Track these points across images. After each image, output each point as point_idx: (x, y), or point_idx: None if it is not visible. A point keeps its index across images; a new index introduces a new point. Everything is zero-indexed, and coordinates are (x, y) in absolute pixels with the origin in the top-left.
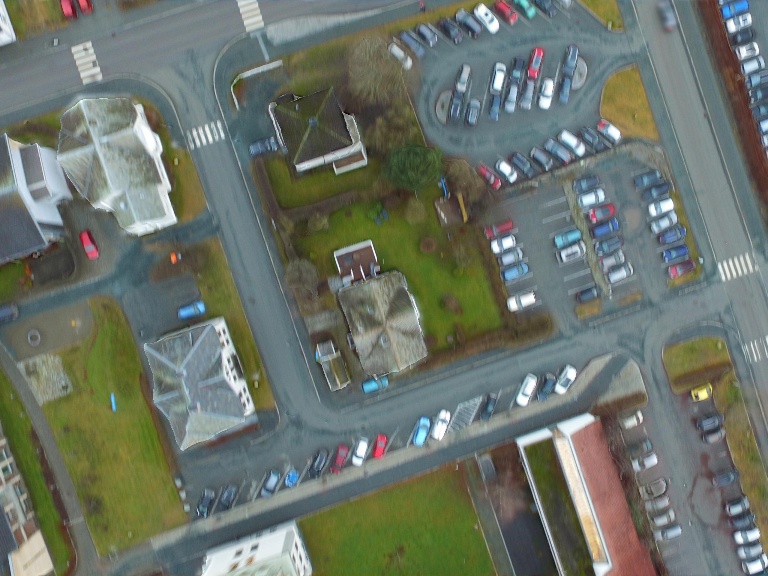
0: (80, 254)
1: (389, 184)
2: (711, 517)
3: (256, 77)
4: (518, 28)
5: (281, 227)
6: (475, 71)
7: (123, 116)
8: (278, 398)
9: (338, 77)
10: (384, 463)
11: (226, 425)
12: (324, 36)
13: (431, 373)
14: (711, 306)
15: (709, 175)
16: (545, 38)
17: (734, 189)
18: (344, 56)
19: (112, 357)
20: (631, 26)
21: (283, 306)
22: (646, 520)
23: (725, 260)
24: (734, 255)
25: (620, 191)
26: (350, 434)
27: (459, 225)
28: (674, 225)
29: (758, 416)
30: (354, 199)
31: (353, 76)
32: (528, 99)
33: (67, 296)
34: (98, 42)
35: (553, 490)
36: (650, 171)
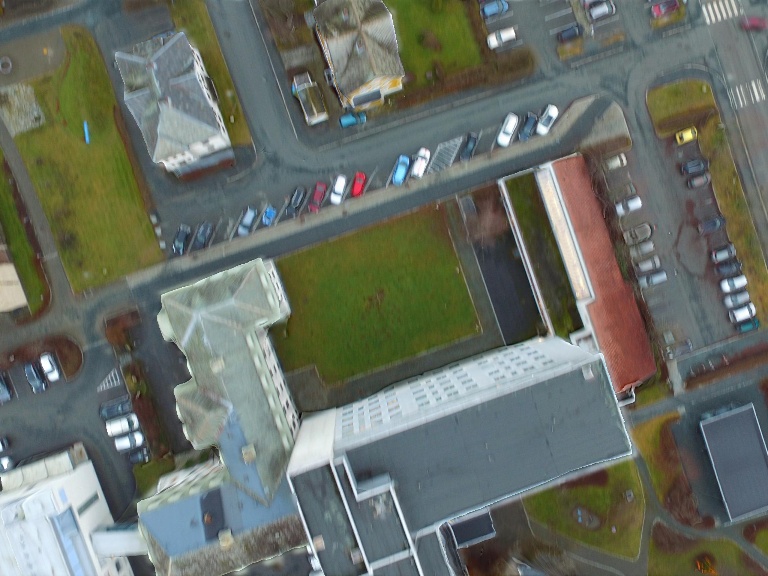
0: None
1: None
2: (697, 266)
3: None
4: None
5: None
6: None
7: None
8: (255, 135)
9: None
10: (363, 203)
11: (199, 134)
12: None
13: (410, 112)
14: (695, 49)
15: None
16: None
17: None
18: None
19: (85, 84)
20: None
21: (259, 40)
22: (631, 267)
23: (709, 3)
24: None
25: None
26: (328, 173)
27: None
28: None
29: (744, 163)
30: None
31: None
32: None
33: (39, 24)
34: None
35: (535, 226)
36: None
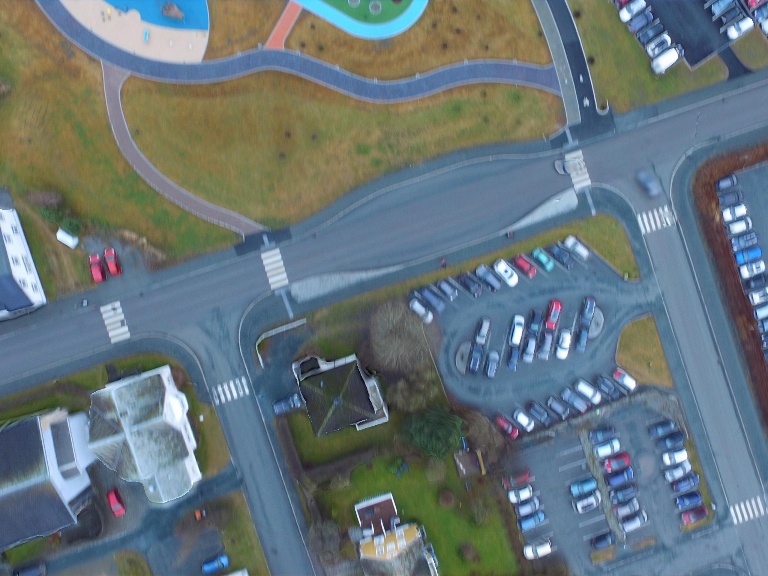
0: (107, 512)
1: (410, 446)
2: None
3: (280, 335)
4: (536, 280)
5: (304, 487)
6: (494, 322)
7: (152, 396)
8: None
9: (360, 330)
10: None
11: None
12: (347, 293)
13: None
14: (723, 549)
15: (722, 420)
16: (563, 289)
17: (746, 434)
18: (366, 311)
19: None
20: (647, 276)
21: (304, 556)
22: None
23: (737, 503)
24: (746, 498)
25: (635, 439)
26: None
27: (477, 476)
28: (687, 473)
29: None
30: (375, 454)
31: (376, 348)
32: (546, 351)
33: (94, 552)
34: (126, 302)
35: None
36: (664, 421)
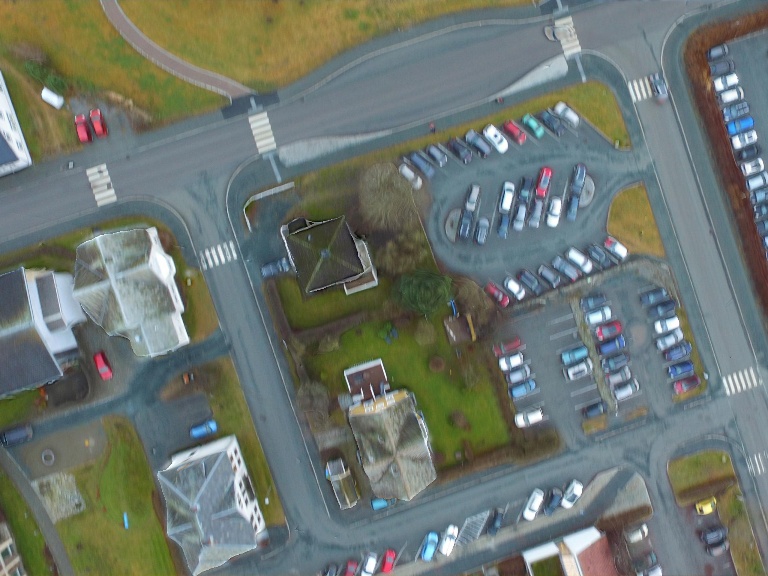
0: (94, 375)
1: (399, 307)
2: None
3: (268, 199)
4: (527, 147)
5: (292, 349)
6: (484, 189)
7: (138, 248)
8: (288, 514)
9: (349, 196)
10: None
11: (238, 552)
12: (335, 157)
13: (439, 488)
14: (716, 420)
15: (714, 291)
16: (553, 156)
17: (739, 304)
18: (355, 176)
19: (125, 477)
20: (638, 144)
21: (294, 423)
22: None
23: (730, 374)
24: (738, 369)
25: (626, 308)
26: (359, 549)
27: (468, 343)
28: (680, 342)
29: (761, 528)
30: (364, 319)
31: (364, 204)
32: (536, 218)
33: (81, 416)
34: (113, 164)
35: None
36: (656, 289)
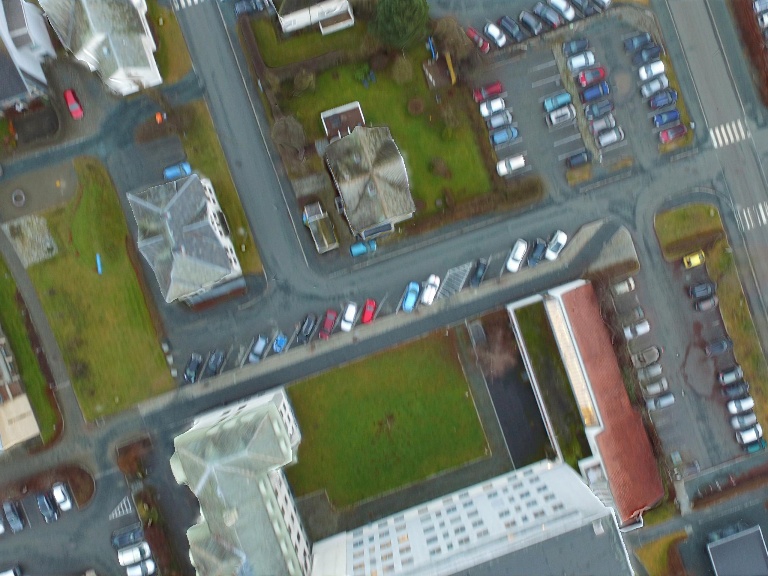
0: (64, 113)
1: (376, 40)
2: (704, 387)
3: None
4: None
5: (267, 85)
6: None
7: None
8: (266, 262)
9: None
10: (373, 329)
11: (212, 276)
12: None
13: (420, 238)
14: (703, 173)
15: (700, 40)
16: None
17: (726, 55)
18: None
19: (97, 217)
20: None
21: (270, 169)
22: (639, 389)
23: (717, 126)
24: (726, 121)
25: (610, 55)
26: (339, 299)
27: (447, 88)
28: (665, 89)
29: (751, 285)
30: (341, 59)
31: None
32: None
33: (52, 157)
34: None
35: (544, 354)
36: (640, 34)
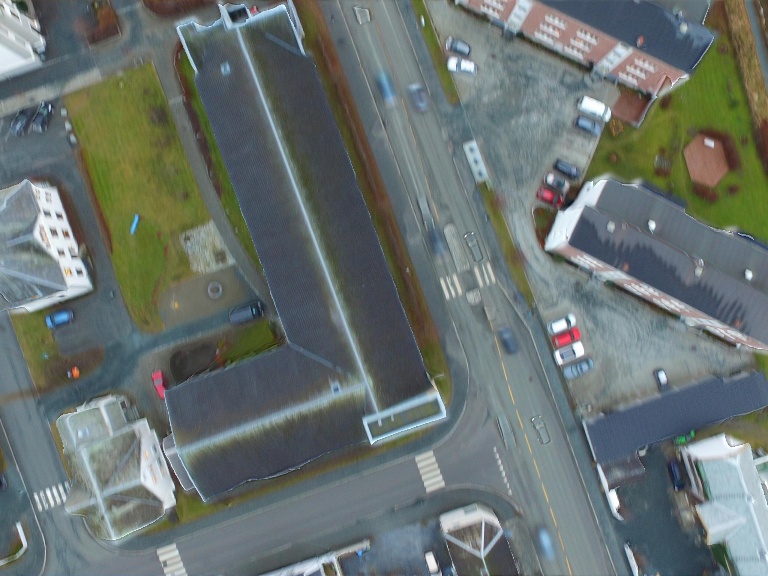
0: None
1: None
2: None
3: (2, 556)
4: None
5: None
6: None
7: None
8: None
9: None
10: None
11: None
12: None
13: None
14: None
15: None
16: None
17: None
18: None
19: (133, 272)
20: None
21: None
22: None
23: None
24: None
25: None
26: None
27: None
28: None
29: None
30: None
31: None
32: None
33: (186, 332)
34: None
35: None
36: None
